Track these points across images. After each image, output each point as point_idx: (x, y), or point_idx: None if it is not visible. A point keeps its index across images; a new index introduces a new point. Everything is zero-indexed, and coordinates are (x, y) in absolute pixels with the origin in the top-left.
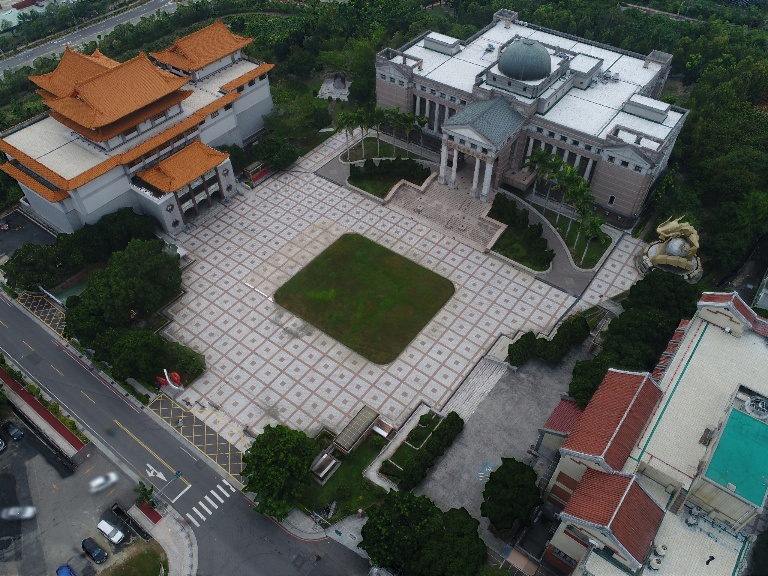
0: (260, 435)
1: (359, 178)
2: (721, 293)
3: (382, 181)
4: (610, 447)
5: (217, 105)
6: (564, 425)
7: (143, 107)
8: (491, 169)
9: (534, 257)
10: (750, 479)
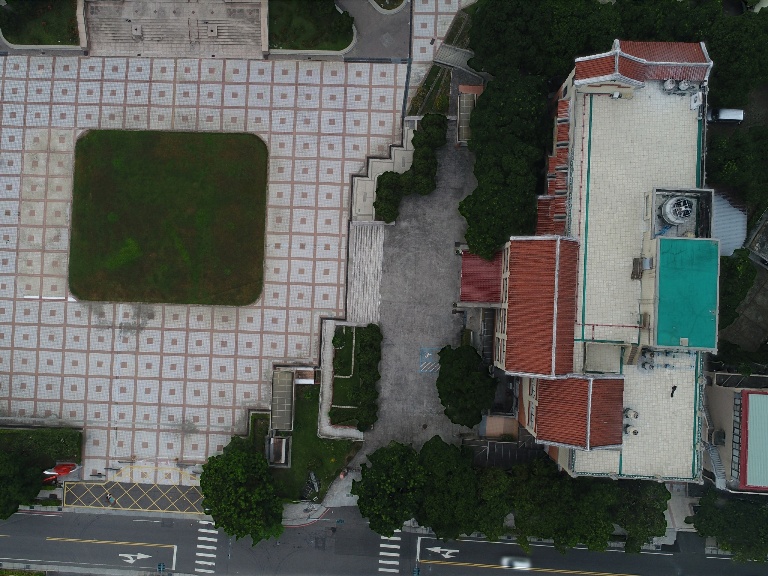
0: (203, 486)
1: (17, 25)
2: (599, 56)
3: (52, 11)
4: (555, 356)
5: None
6: (481, 288)
7: None
8: None
9: (327, 29)
10: (698, 321)
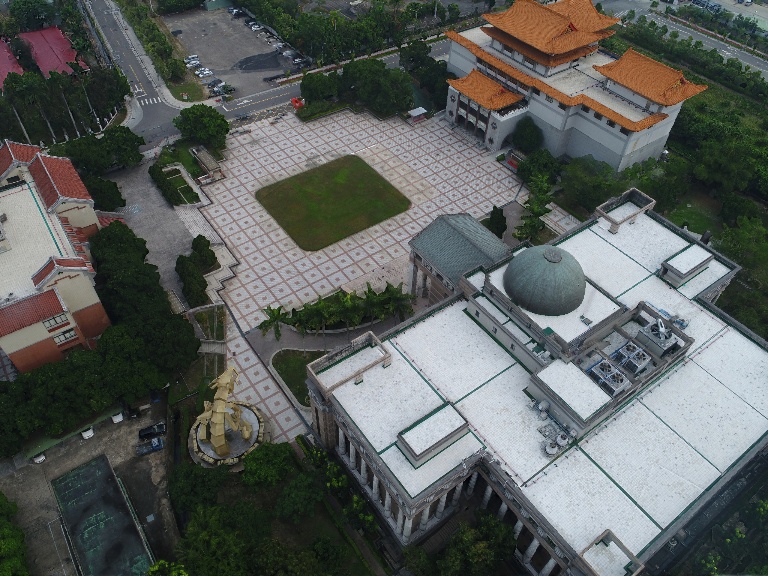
0: None
1: None
2: None
3: None
4: None
5: (552, 92)
6: None
7: (516, 38)
8: (412, 269)
9: None
10: None
